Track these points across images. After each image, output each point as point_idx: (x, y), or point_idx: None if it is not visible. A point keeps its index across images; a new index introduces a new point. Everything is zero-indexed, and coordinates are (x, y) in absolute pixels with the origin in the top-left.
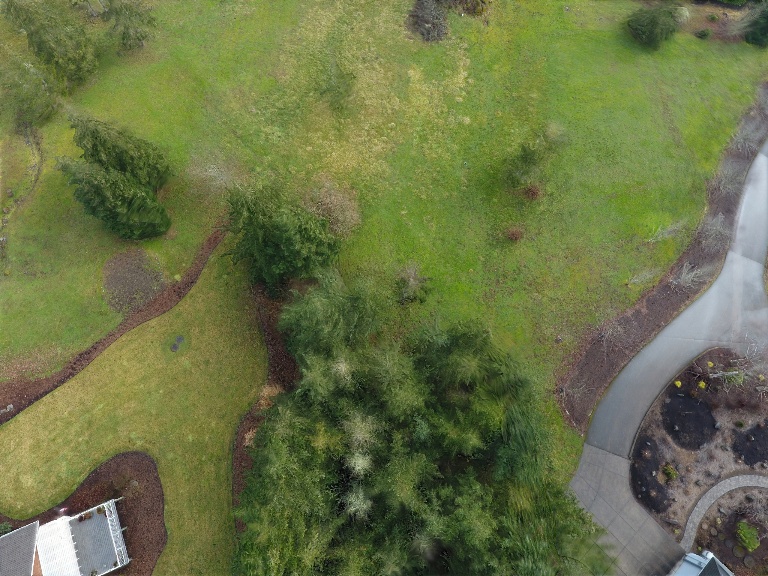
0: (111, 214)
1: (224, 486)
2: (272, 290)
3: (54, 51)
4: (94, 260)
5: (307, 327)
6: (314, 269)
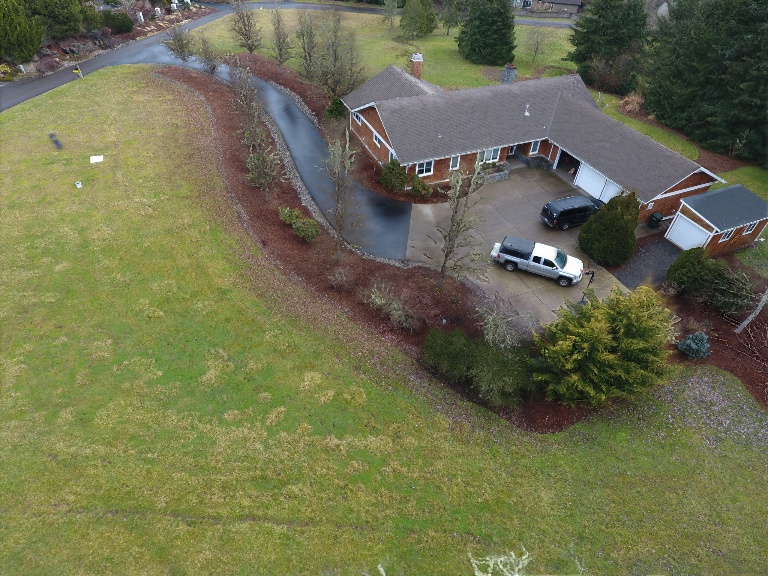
0: (502, 25)
1: (629, 118)
2: (607, 61)
3: (427, 6)
4: (470, 69)
5: (682, 7)
6: (641, 39)
